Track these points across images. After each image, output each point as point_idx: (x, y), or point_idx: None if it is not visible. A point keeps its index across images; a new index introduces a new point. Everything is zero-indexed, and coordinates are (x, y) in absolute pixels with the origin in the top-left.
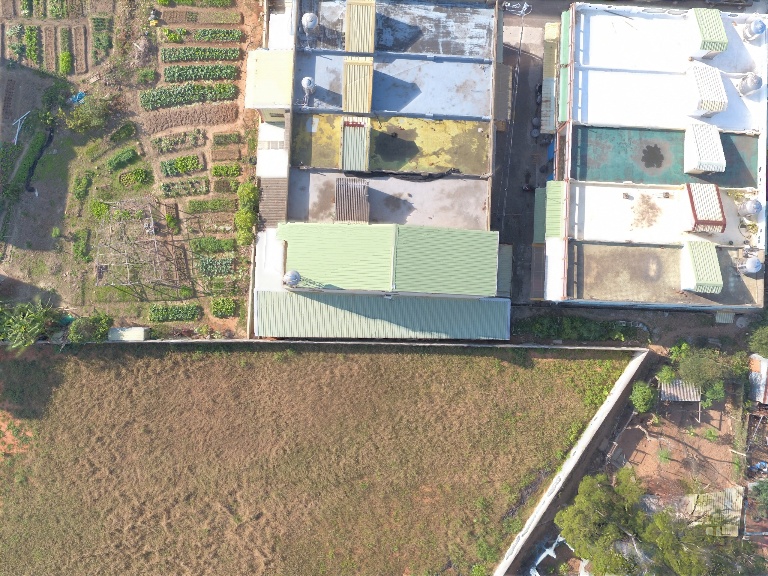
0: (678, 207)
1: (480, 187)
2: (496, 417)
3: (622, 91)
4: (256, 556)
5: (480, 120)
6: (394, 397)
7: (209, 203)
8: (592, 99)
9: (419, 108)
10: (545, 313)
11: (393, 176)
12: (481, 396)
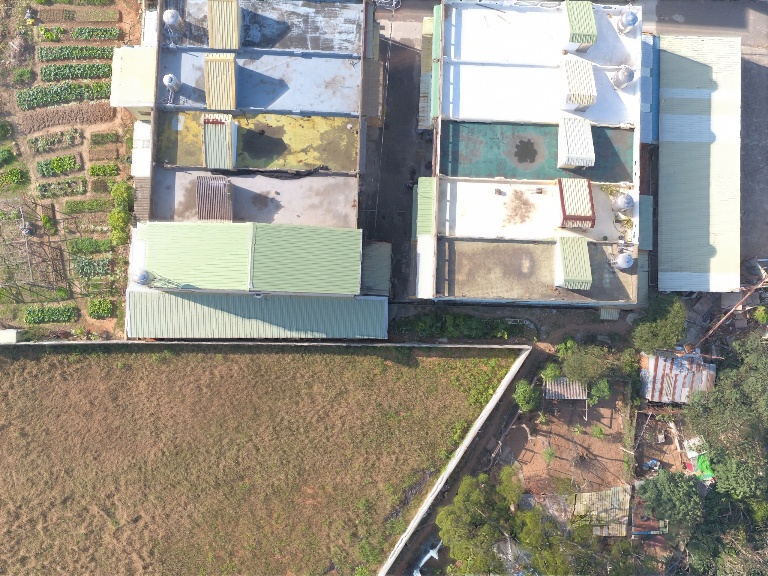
0: (551, 202)
1: (349, 184)
2: (379, 417)
3: (494, 85)
4: (134, 560)
5: (349, 116)
6: (275, 398)
7: (86, 203)
8: (463, 94)
9: (287, 105)
10: (430, 311)
11: (260, 174)
12: (364, 396)
